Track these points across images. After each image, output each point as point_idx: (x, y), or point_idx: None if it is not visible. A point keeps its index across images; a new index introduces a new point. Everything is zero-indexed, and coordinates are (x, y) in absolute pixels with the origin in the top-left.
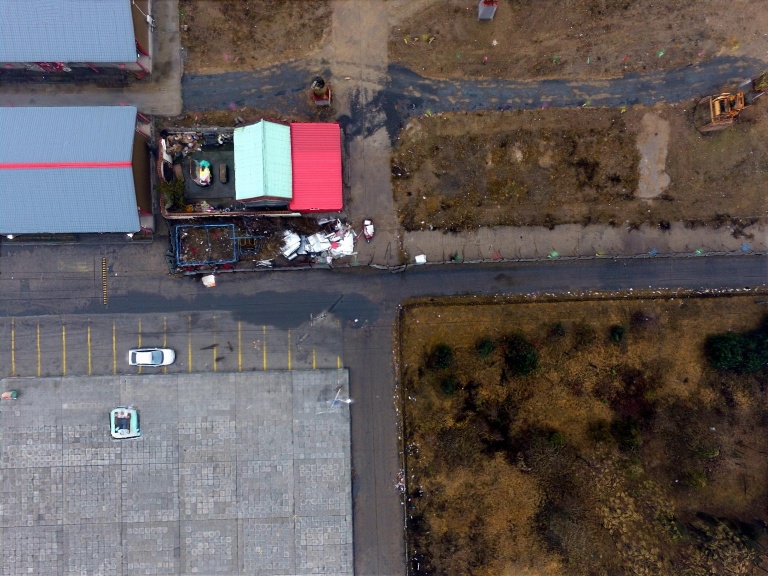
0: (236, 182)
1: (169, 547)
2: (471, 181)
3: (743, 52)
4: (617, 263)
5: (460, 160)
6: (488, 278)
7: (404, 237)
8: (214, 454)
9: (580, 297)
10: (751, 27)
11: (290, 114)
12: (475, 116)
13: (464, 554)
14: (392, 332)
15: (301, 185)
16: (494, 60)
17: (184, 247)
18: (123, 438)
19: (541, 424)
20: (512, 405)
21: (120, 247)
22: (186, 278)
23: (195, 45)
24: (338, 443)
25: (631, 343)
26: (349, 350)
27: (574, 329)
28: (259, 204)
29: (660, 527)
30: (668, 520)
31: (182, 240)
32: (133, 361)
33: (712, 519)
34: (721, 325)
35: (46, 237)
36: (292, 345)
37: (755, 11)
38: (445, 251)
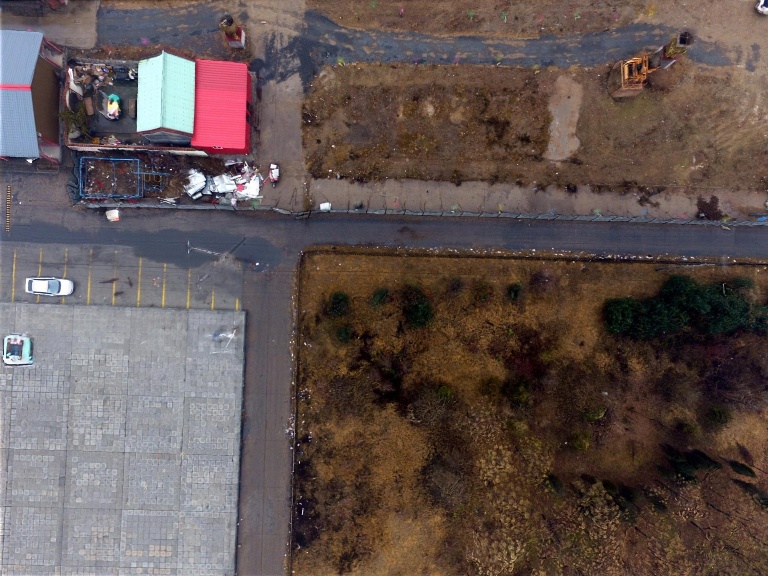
0: (138, 114)
1: (54, 476)
2: (381, 133)
3: (661, 21)
4: (521, 223)
5: (371, 111)
6: (392, 230)
7: (311, 184)
8: (105, 387)
9: (482, 254)
10: None
11: (204, 54)
12: (389, 68)
13: (349, 502)
14: (292, 278)
15: (204, 122)
16: (411, 13)
17: (90, 180)
18: (15, 365)
19: (434, 378)
20: (407, 357)
21: (26, 176)
22: (90, 211)
23: None
24: (230, 384)
25: (529, 303)
26: (248, 293)
27: (473, 286)
28: (162, 139)
29: (533, 480)
30: (540, 473)
31: (88, 173)
32: (29, 289)
33: (593, 480)
34: (621, 291)
35: None
36: (192, 284)
37: None
38: (350, 200)
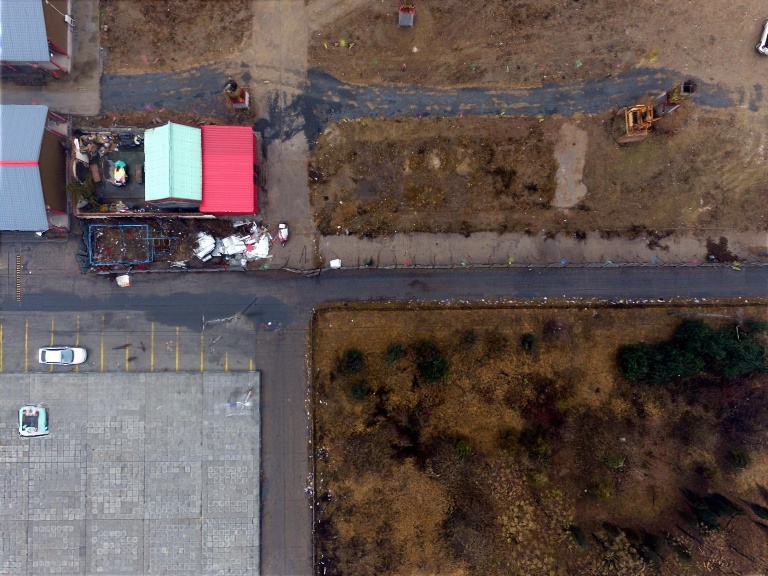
0: (145, 183)
1: (75, 546)
2: (388, 187)
3: (662, 64)
4: (532, 272)
5: (378, 166)
6: (403, 284)
7: (320, 241)
8: (122, 454)
9: (494, 305)
10: (671, 40)
11: (208, 116)
12: (393, 122)
13: (371, 559)
14: (305, 336)
15: (212, 187)
16: (414, 67)
17: (99, 246)
18: (31, 436)
19: (451, 431)
20: (423, 411)
21: (35, 245)
22: (100, 277)
23: (115, 45)
24: (247, 445)
25: (543, 352)
26: (262, 353)
27: (486, 337)
28: (170, 205)
29: (556, 537)
30: (563, 530)
31: (97, 239)
32: (43, 359)
33: (615, 530)
34: (634, 336)
35: None
36: (205, 347)
37: (675, 24)
38: (360, 256)
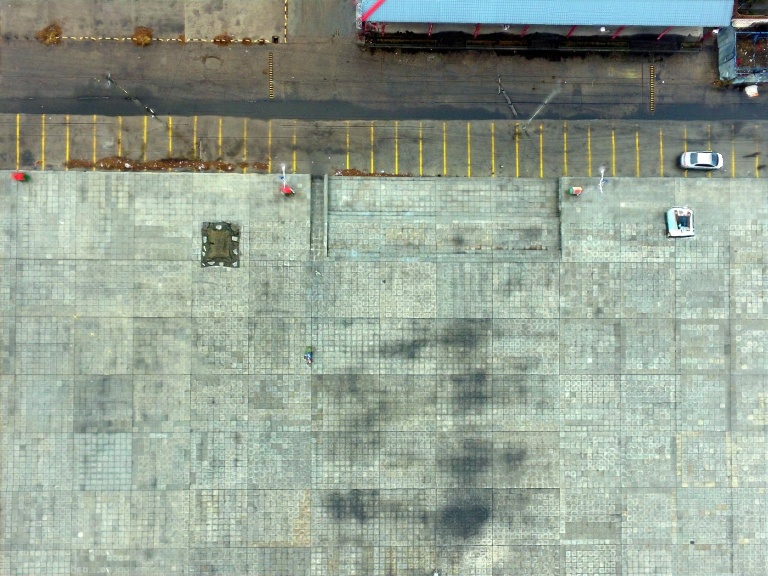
0: None
1: (720, 344)
2: None
3: None
4: None
5: None
6: None
7: None
8: (764, 256)
9: None
10: None
11: None
12: None
13: None
14: None
15: None
16: None
17: None
18: (679, 237)
19: None
20: None
21: (668, 55)
22: (731, 87)
23: None
24: None
25: None
26: None
27: None
28: None
29: None
30: None
31: None
32: (693, 161)
33: None
34: None
35: (601, 43)
36: None
37: None
38: None
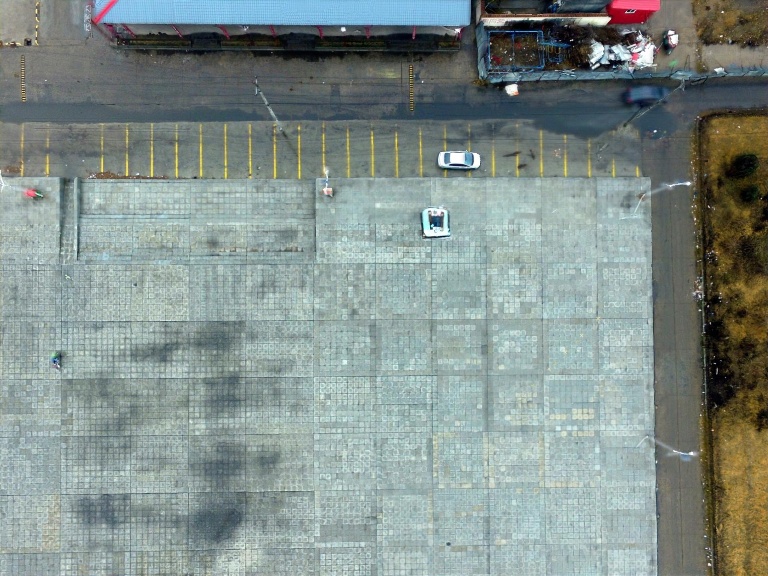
0: None
1: (477, 344)
2: None
3: None
4: None
5: None
6: None
7: (702, 50)
8: (521, 255)
9: None
10: None
11: None
12: None
13: (762, 360)
14: (690, 143)
15: None
16: None
17: None
18: (434, 237)
19: None
20: None
21: (427, 55)
22: (490, 86)
23: None
24: (641, 248)
25: None
26: (648, 160)
27: None
28: (578, 5)
29: None
30: None
31: None
32: (446, 161)
33: None
34: None
35: (357, 43)
36: (592, 154)
37: None
38: (743, 64)
